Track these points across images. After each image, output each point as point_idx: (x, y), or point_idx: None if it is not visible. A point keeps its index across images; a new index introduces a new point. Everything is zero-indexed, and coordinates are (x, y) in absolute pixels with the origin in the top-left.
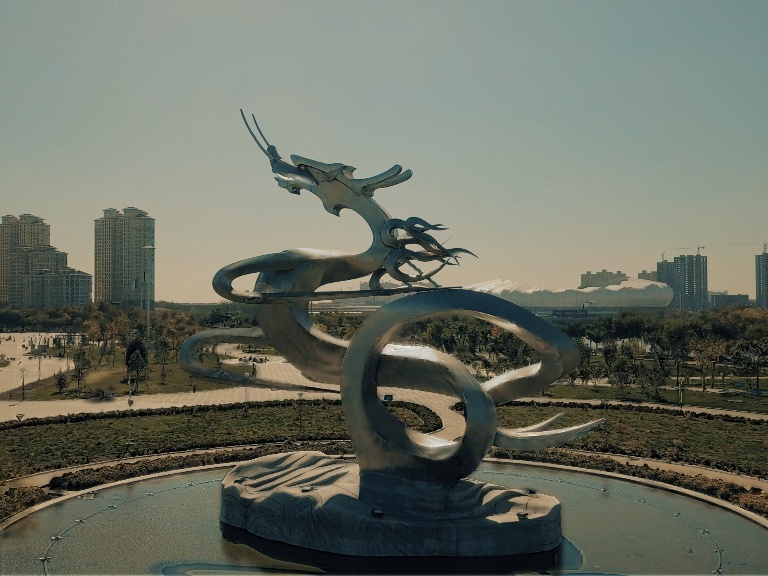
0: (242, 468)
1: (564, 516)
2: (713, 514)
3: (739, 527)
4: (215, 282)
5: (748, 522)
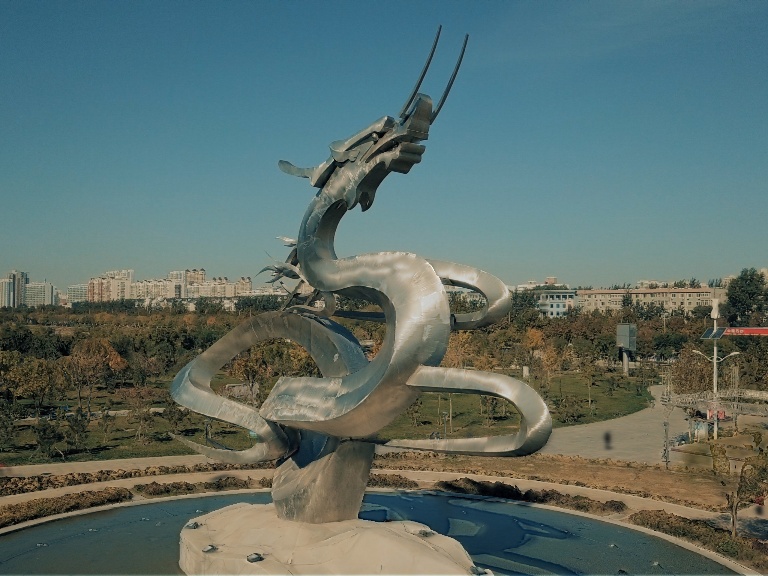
0: (467, 570)
1: (122, 569)
2: (13, 541)
3: (53, 529)
4: (508, 299)
5: (31, 529)
